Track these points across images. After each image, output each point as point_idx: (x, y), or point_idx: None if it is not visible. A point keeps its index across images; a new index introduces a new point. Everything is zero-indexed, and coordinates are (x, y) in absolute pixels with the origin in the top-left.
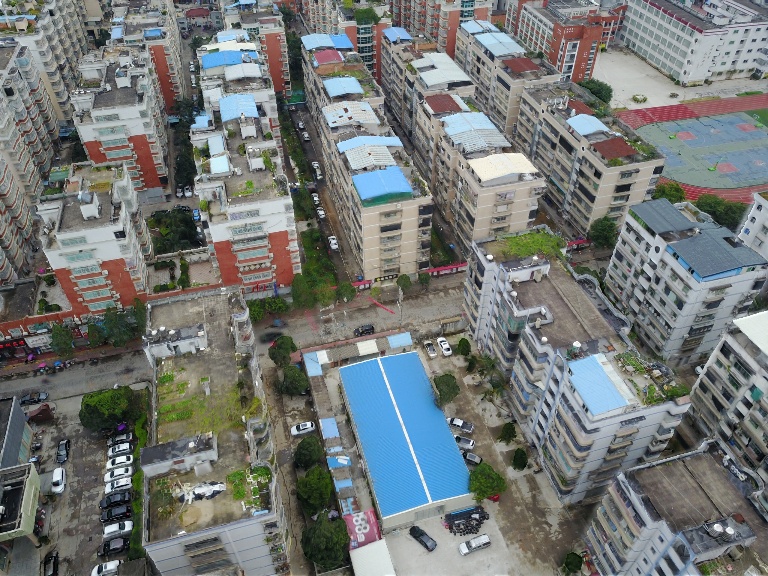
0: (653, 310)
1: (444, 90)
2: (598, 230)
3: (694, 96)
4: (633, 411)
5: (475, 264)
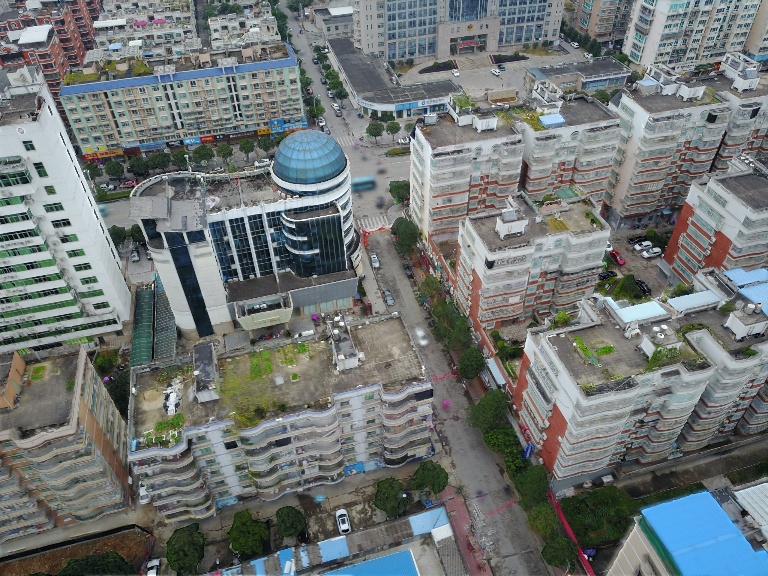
0: None
1: None
2: None
3: None
4: None
5: None
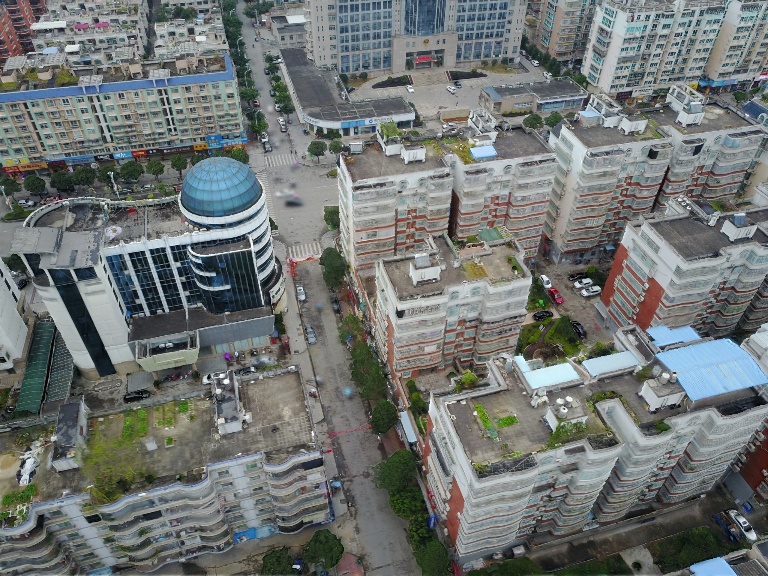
0: None
1: None
2: None
3: None
4: None
5: None
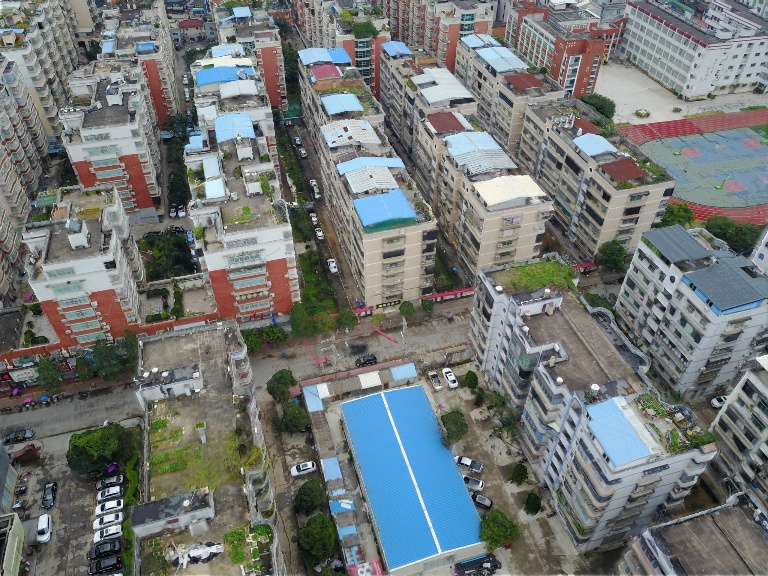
0: (668, 341)
1: (446, 107)
2: (607, 254)
3: (697, 111)
4: (656, 460)
5: (483, 294)
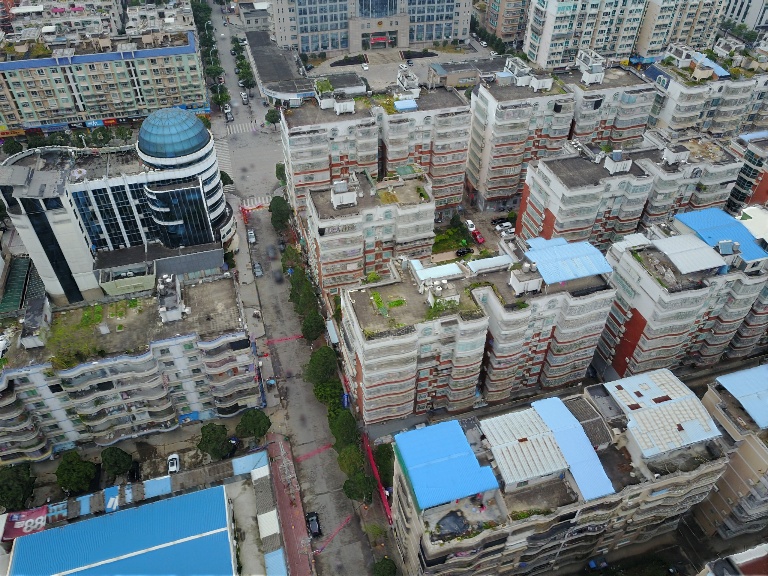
0: None
1: None
2: None
3: None
4: None
5: None
